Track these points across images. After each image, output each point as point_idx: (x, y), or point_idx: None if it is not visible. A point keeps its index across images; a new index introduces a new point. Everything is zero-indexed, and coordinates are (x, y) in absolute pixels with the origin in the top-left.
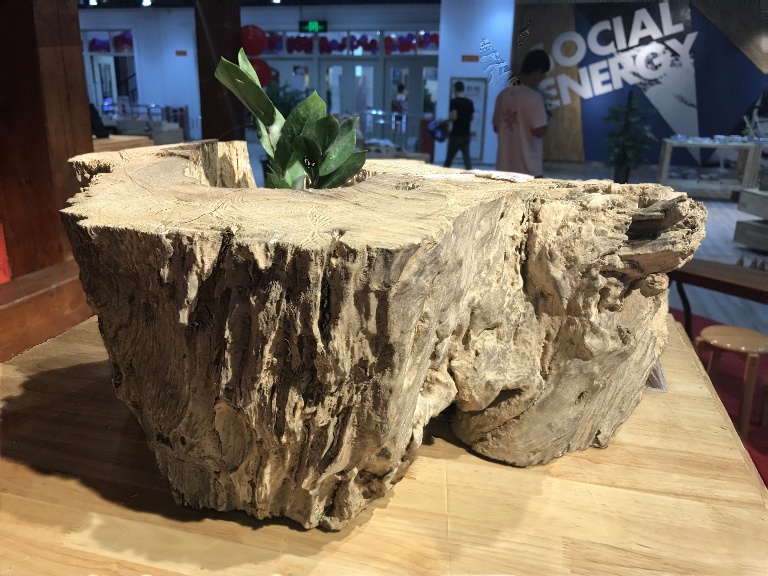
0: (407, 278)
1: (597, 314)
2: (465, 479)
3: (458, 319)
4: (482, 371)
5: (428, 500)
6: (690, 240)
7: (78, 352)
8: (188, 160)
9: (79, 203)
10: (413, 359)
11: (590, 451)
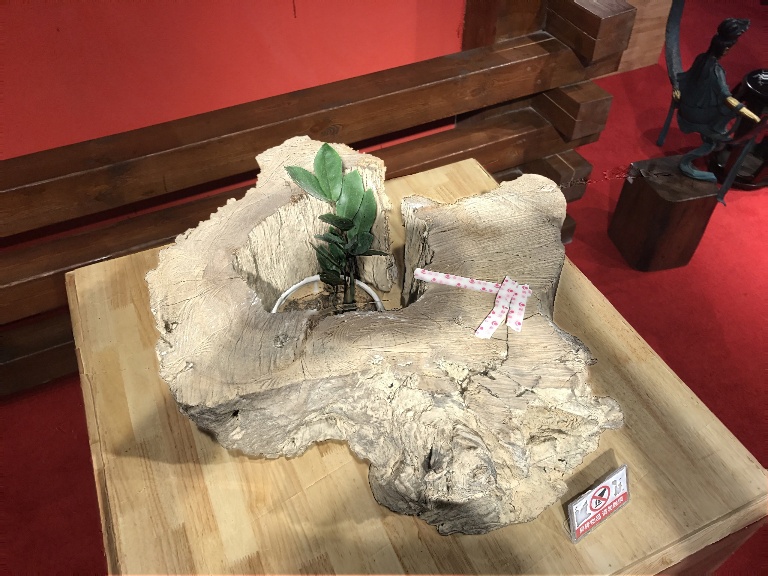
0: (193, 413)
1: (412, 474)
2: (342, 479)
3: (333, 411)
4: (354, 442)
5: (308, 474)
6: (449, 494)
7: None
8: (288, 201)
9: (172, 247)
10: (240, 430)
11: (431, 528)
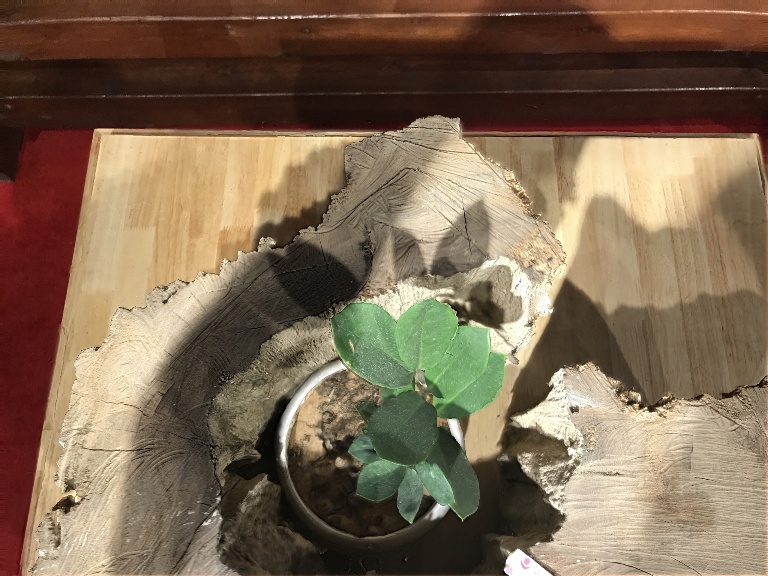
0: None
1: None
2: None
3: None
4: None
5: None
6: None
7: None
8: (356, 293)
9: (138, 311)
10: None
11: None
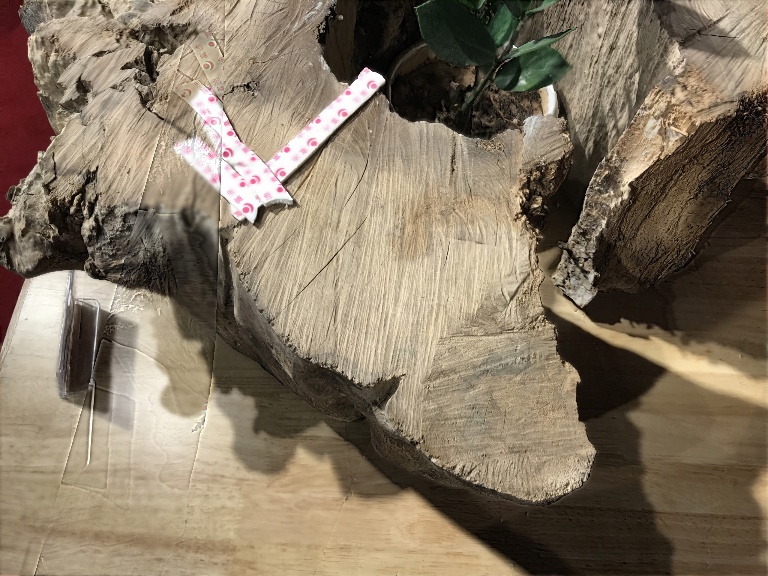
0: None
1: None
2: None
3: None
4: None
5: None
6: None
7: (764, 239)
8: None
9: None
10: None
11: None
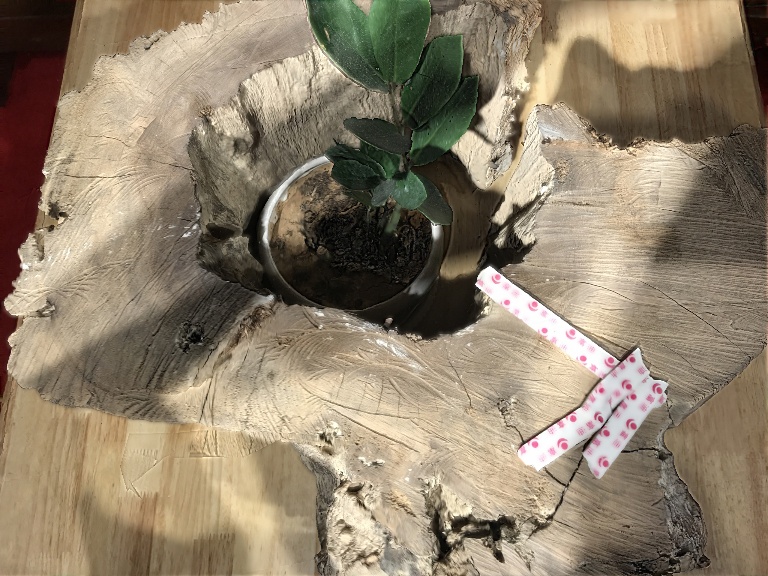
0: None
1: None
2: None
3: None
4: None
5: None
6: None
7: None
8: None
9: (120, 57)
10: None
11: None
